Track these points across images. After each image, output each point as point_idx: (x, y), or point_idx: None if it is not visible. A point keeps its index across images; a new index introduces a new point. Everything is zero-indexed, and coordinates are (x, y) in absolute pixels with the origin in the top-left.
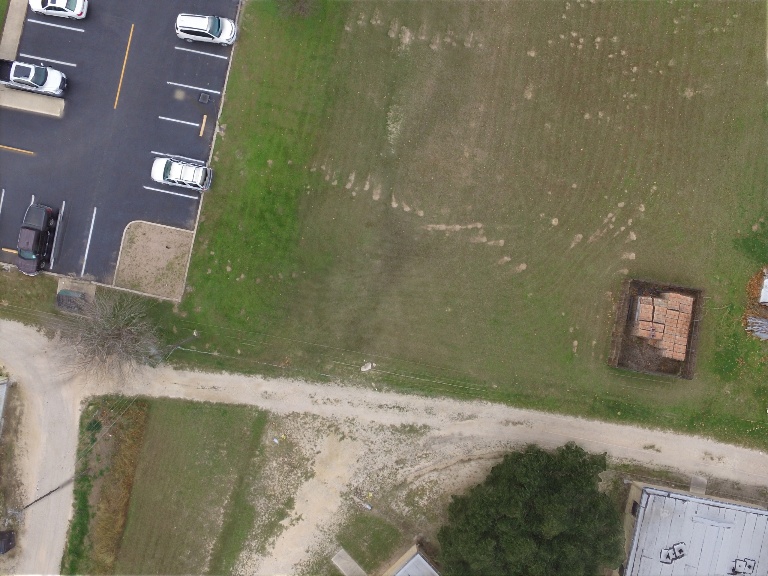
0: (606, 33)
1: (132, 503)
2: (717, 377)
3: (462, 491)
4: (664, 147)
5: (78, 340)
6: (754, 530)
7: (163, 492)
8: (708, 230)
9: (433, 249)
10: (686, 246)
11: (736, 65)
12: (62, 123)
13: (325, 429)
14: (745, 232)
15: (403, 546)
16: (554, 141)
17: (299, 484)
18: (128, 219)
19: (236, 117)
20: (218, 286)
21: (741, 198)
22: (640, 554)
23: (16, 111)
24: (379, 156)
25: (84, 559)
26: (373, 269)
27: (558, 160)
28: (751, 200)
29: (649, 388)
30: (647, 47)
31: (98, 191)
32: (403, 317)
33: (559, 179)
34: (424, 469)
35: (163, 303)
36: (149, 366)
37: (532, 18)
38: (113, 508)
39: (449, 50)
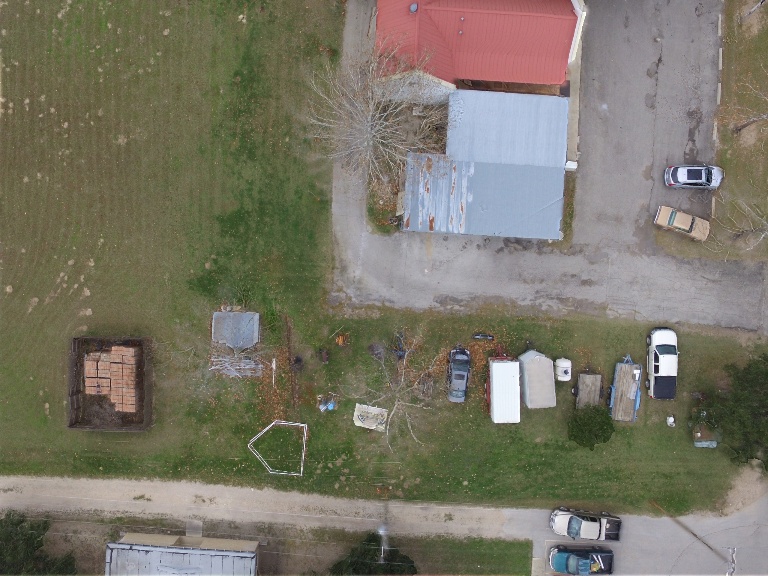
0: (34, 93)
1: None
2: (192, 420)
3: None
4: (106, 198)
5: None
6: (222, 572)
7: None
8: (161, 274)
9: None
10: (141, 294)
11: (166, 103)
12: None
13: None
14: (199, 271)
15: None
16: None
17: None
18: None
19: None
20: None
21: (189, 237)
22: None
23: None
24: None
25: None
26: None
27: (5, 227)
28: (200, 238)
29: (125, 440)
30: (75, 100)
31: None
32: None
33: (8, 246)
34: None
35: None
36: None
37: None
38: None
39: None
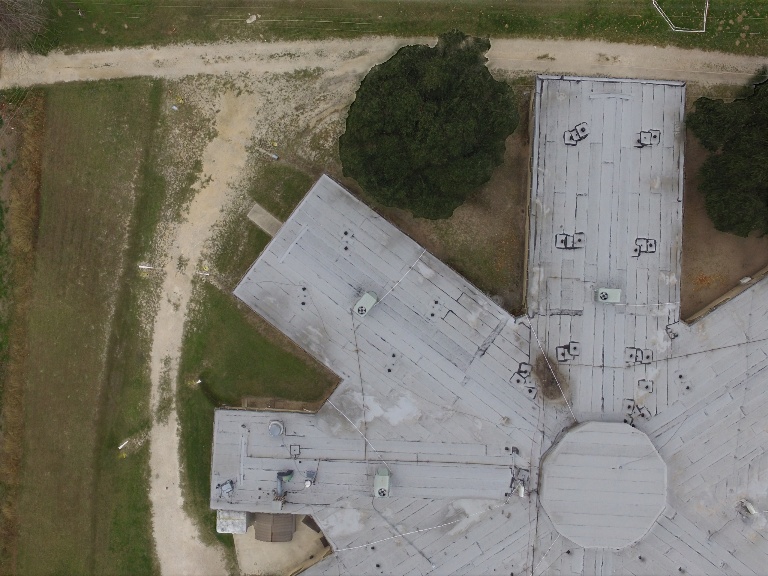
0: None
1: (43, 192)
2: None
3: None
4: None
5: None
6: (653, 101)
7: (72, 176)
8: None
9: None
10: None
11: None
12: None
13: (221, 87)
14: None
15: None
16: None
17: (204, 146)
18: None
19: None
20: None
21: None
22: (543, 140)
23: None
24: None
25: (4, 255)
26: None
27: None
28: None
29: None
30: None
31: None
32: None
33: None
34: (324, 112)
35: None
36: (41, 55)
37: None
38: (24, 197)
39: None
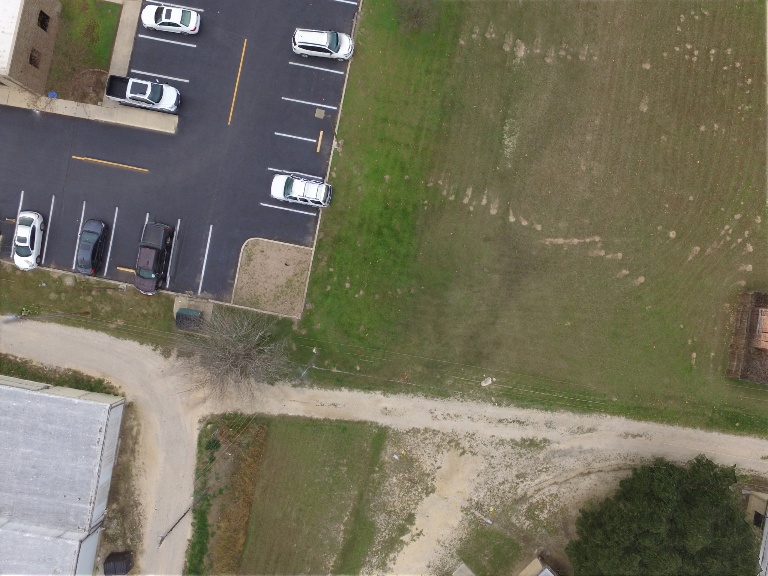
0: (720, 45)
1: (252, 521)
2: None
3: (582, 504)
4: None
5: (195, 359)
6: None
7: (283, 510)
8: None
9: (551, 263)
10: None
11: None
12: (177, 140)
13: (445, 444)
14: None
15: (524, 560)
16: (671, 154)
17: (420, 500)
18: (245, 236)
19: (353, 133)
20: (337, 303)
21: None
22: (766, 564)
23: (130, 128)
24: (496, 170)
25: None
26: (492, 284)
27: (675, 173)
28: None
29: (767, 399)
30: (761, 59)
31: (214, 208)
32: (522, 331)
33: (676, 192)
34: (544, 483)
35: (283, 321)
36: (267, 384)
37: (647, 31)
38: (234, 527)
39: (564, 63)
